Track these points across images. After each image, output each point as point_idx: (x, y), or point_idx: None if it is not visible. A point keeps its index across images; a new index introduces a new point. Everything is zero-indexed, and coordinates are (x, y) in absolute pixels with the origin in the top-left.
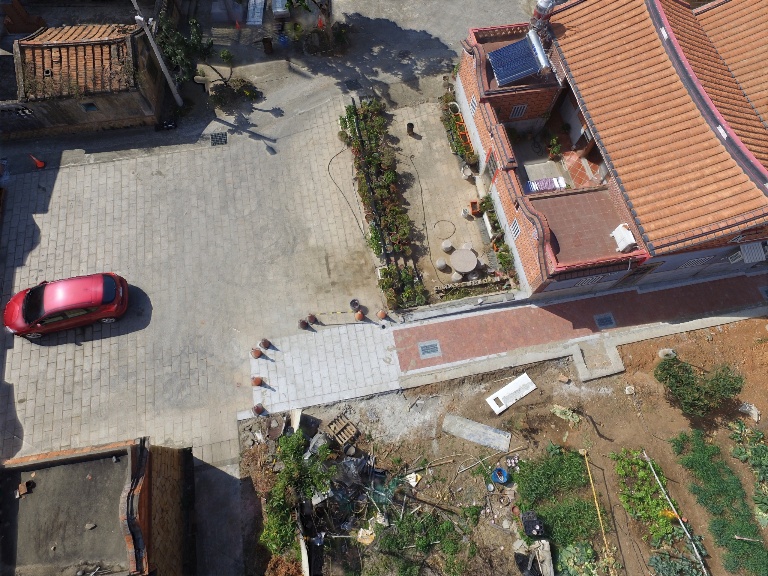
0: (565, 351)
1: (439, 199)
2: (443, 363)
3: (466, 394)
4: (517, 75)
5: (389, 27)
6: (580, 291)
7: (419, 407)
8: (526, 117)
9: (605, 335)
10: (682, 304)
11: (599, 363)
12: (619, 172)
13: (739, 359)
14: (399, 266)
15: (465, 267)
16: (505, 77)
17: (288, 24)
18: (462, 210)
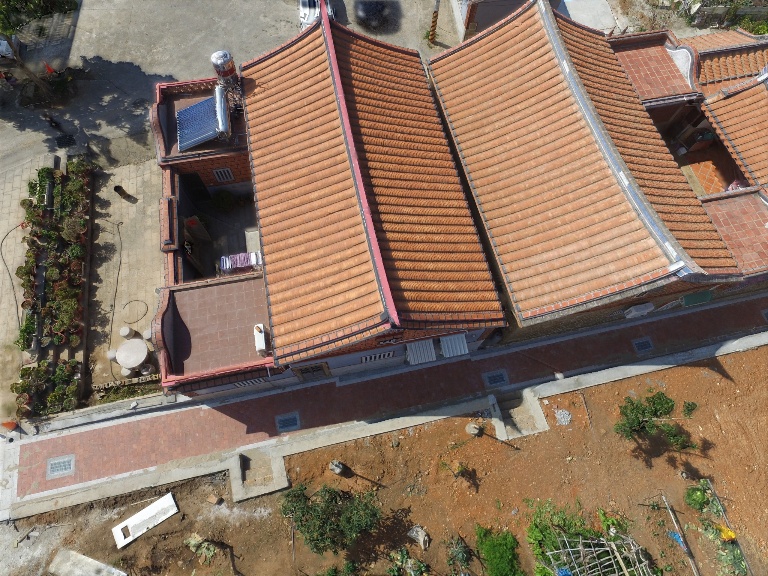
0: (220, 465)
1: (138, 274)
2: (73, 484)
3: (92, 522)
4: (197, 139)
5: (131, 72)
6: (262, 387)
7: (30, 541)
8: (240, 180)
9: (284, 440)
10: (386, 397)
11: (259, 478)
12: (267, 260)
13: (424, 469)
14: (58, 361)
15: (130, 362)
16: (186, 141)
17: (14, 70)
18: (155, 289)
